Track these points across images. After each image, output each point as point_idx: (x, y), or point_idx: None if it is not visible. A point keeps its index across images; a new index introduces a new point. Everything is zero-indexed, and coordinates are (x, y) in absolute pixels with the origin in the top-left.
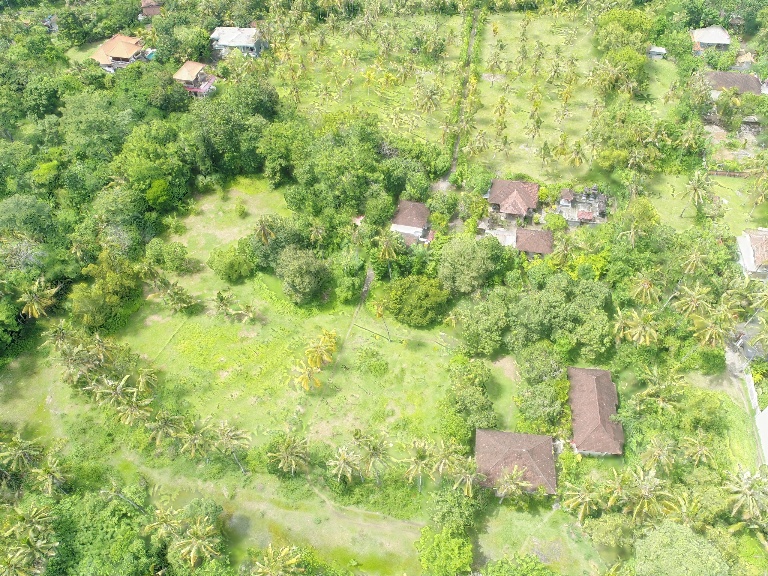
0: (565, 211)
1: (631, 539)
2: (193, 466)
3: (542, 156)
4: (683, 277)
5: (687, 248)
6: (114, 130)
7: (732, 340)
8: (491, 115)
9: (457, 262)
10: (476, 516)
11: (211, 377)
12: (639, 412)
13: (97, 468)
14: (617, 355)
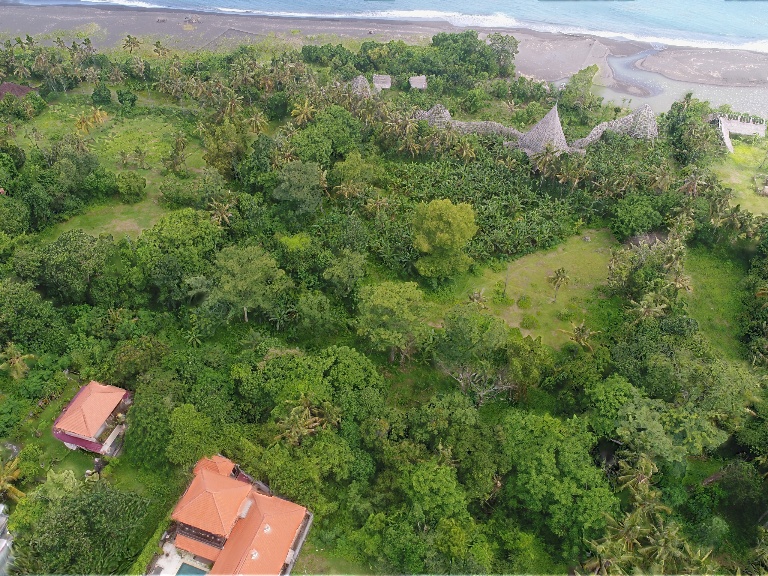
0: None
1: None
2: None
3: None
4: None
5: None
6: None
7: None
8: None
9: None
10: None
11: None
12: None
13: None
14: None
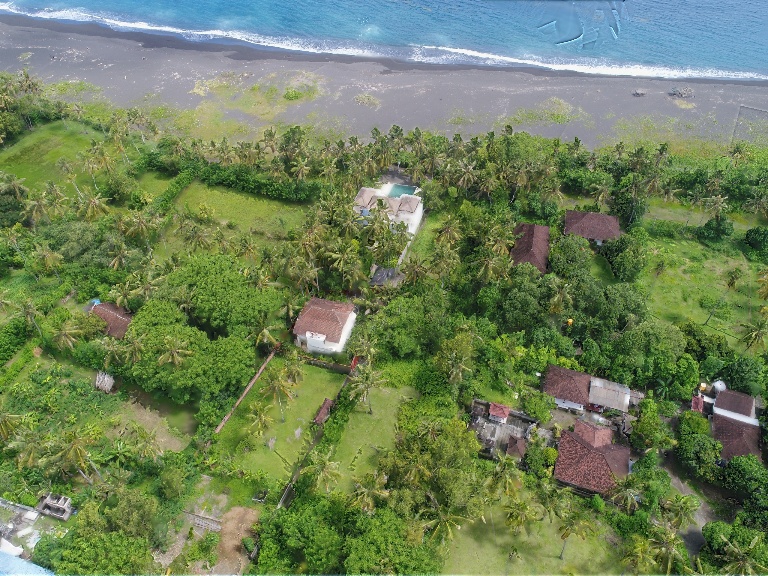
0: None
1: None
2: None
3: None
4: None
5: None
6: None
7: None
8: None
9: None
10: None
11: None
12: None
13: None
14: None
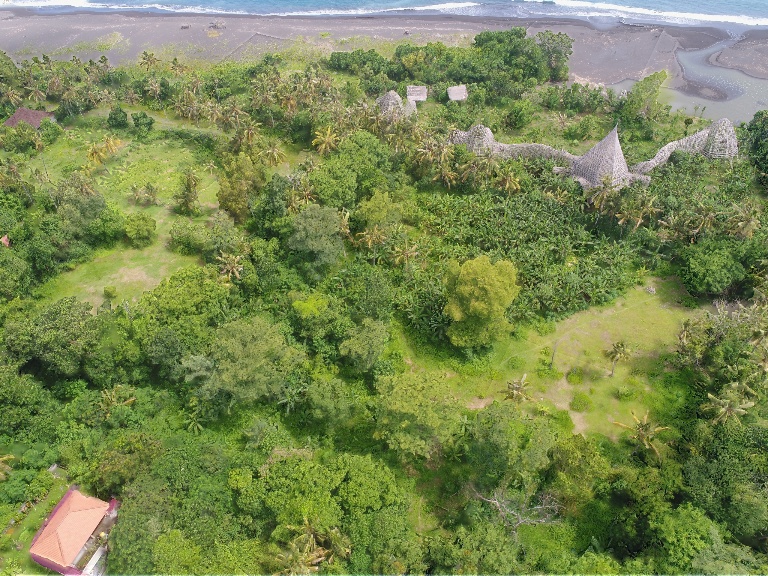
0: None
1: None
2: None
3: None
4: None
5: None
6: None
7: None
8: None
9: None
10: None
11: None
12: None
13: None
14: None
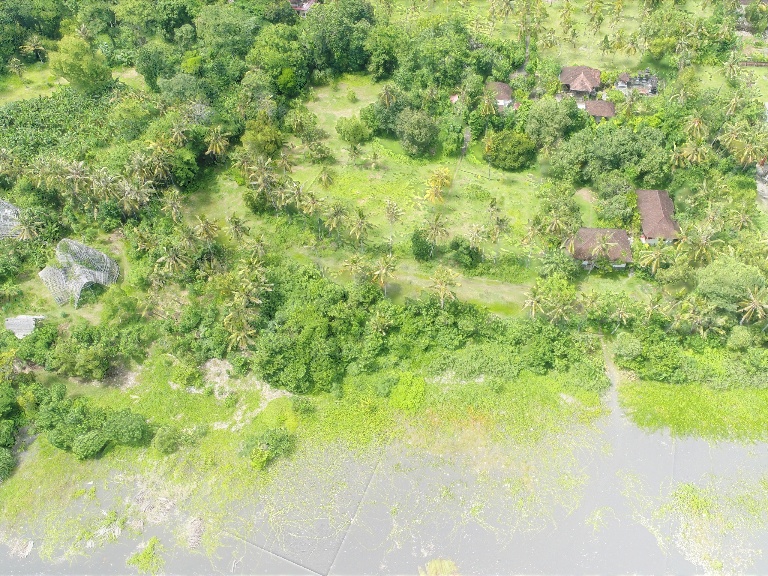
0: (622, 91)
1: (694, 270)
2: (351, 255)
3: (603, 48)
4: (723, 125)
5: (726, 105)
6: (240, 36)
7: (762, 176)
8: (553, 26)
9: (543, 116)
10: (572, 281)
11: (353, 202)
12: (693, 211)
13: (278, 256)
14: (673, 178)
